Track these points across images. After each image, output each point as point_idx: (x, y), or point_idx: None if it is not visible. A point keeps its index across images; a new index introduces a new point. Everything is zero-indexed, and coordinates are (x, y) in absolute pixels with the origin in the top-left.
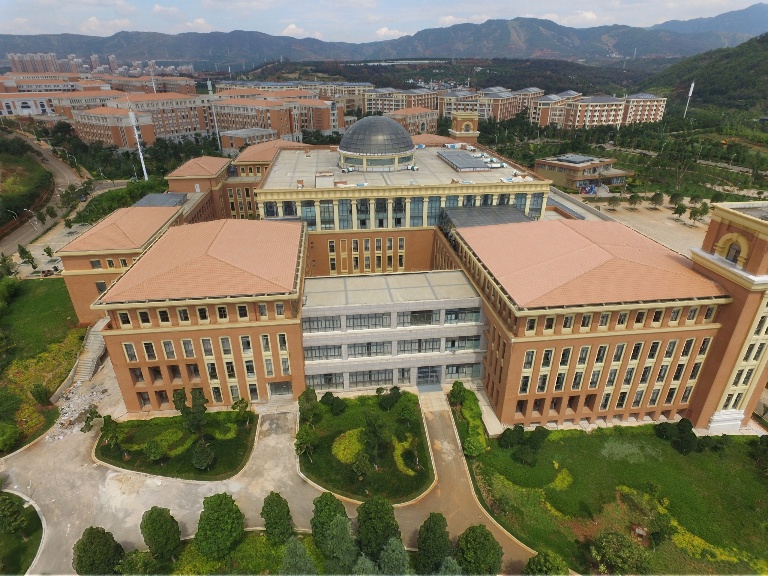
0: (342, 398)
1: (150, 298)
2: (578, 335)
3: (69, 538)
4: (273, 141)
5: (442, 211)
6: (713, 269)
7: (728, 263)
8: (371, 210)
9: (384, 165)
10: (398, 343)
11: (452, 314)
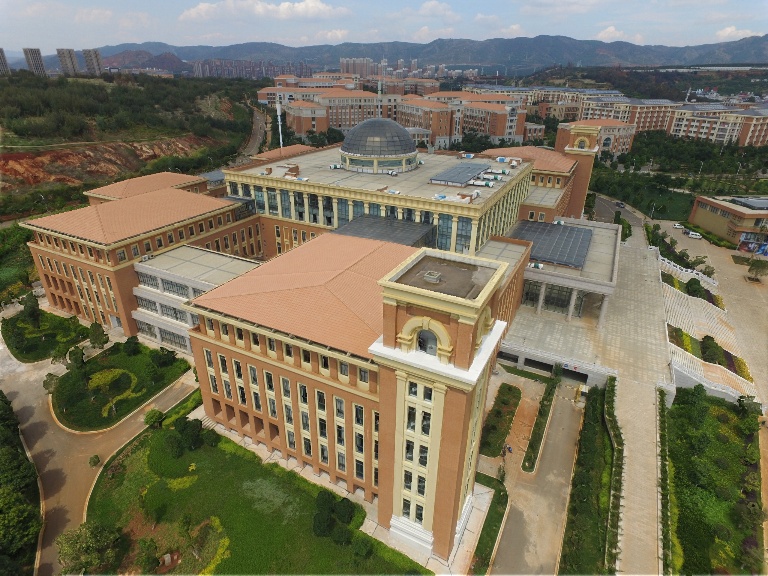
0: (145, 346)
1: (45, 226)
2: (238, 349)
3: None
4: None
5: None
6: None
7: None
8: (305, 204)
9: (365, 166)
10: (193, 316)
11: None
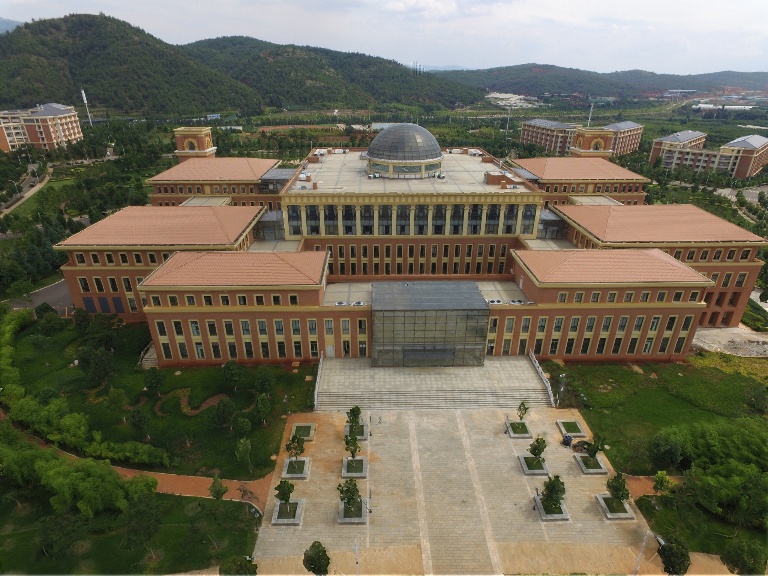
0: None
1: None
2: None
3: None
4: (132, 211)
5: None
6: None
7: (597, 150)
8: None
9: None
10: None
11: None
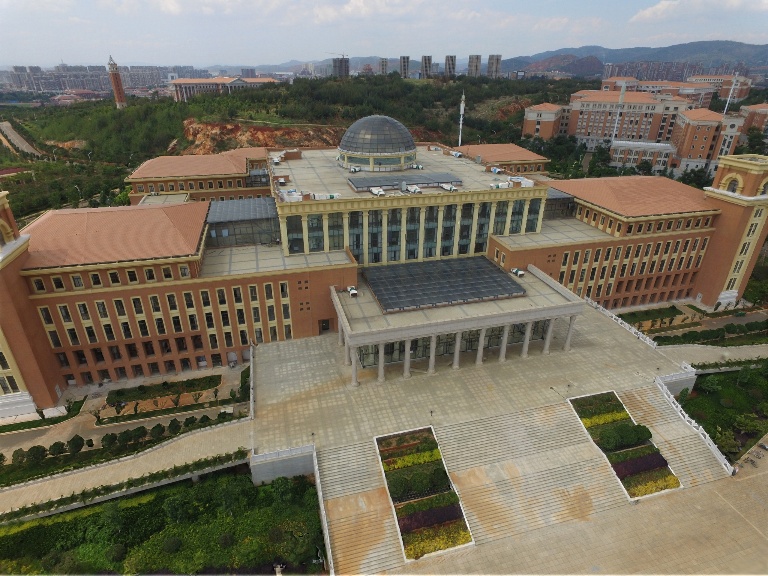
0: None
1: None
2: None
3: None
4: None
5: None
6: None
7: None
8: None
9: None
10: None
11: None
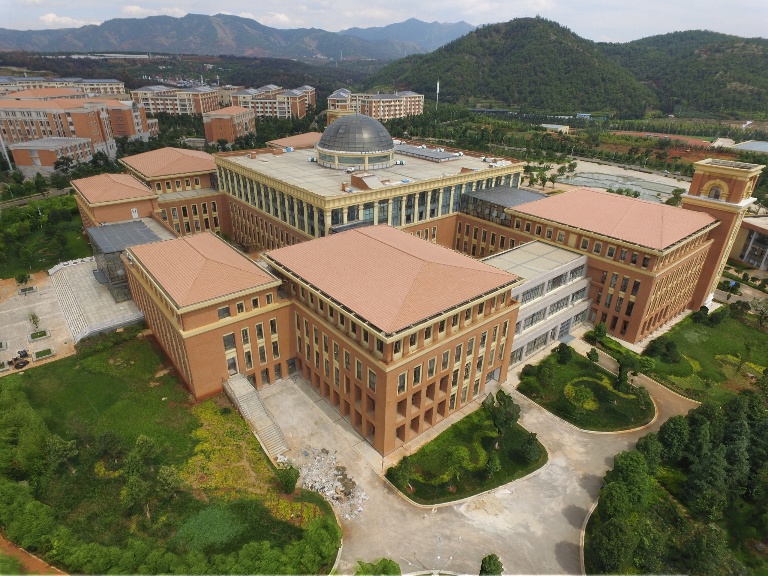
0: None
1: (428, 315)
2: (676, 263)
3: (515, 572)
4: (163, 149)
5: (466, 197)
6: (703, 205)
7: (713, 199)
8: (416, 204)
9: (381, 162)
10: None
11: (571, 274)
